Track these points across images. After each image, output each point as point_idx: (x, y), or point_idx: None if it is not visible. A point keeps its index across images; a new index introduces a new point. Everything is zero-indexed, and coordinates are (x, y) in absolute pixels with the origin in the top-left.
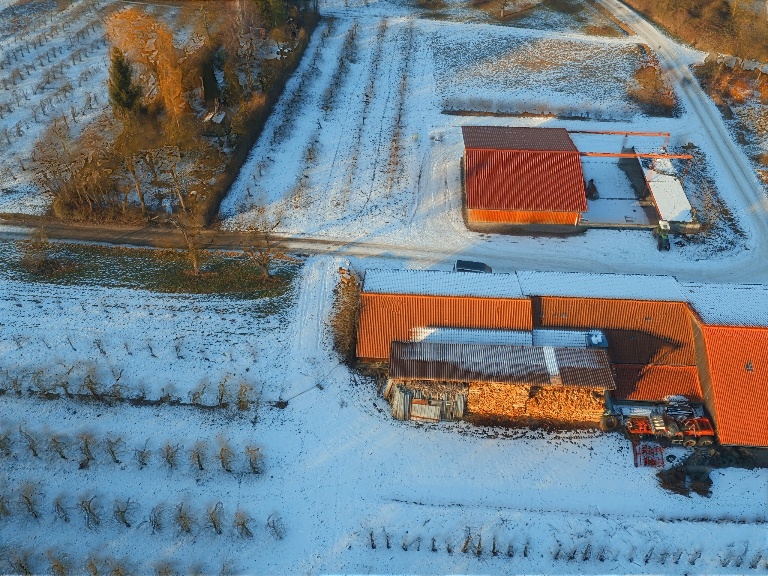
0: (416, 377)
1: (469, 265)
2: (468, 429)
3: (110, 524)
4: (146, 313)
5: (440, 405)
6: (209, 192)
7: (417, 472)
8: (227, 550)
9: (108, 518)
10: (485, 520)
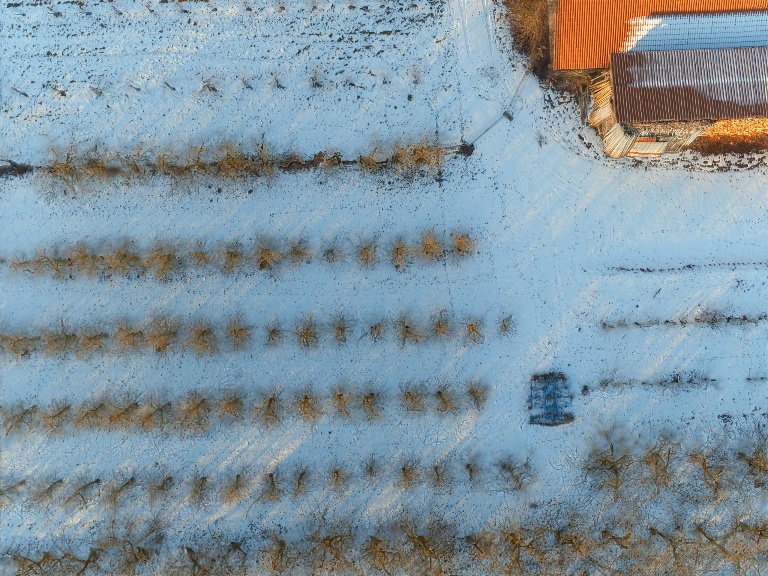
0: (652, 118)
1: None
2: (695, 161)
3: (329, 340)
4: (241, 9)
5: (669, 140)
6: None
7: (640, 229)
8: (454, 346)
9: (327, 338)
10: (719, 283)
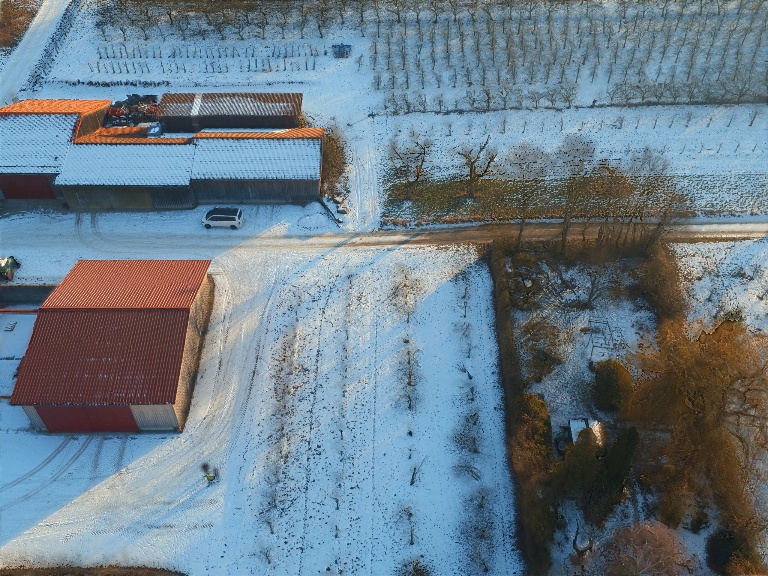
0: None
1: (227, 211)
2: None
3: None
4: None
5: None
6: (510, 283)
7: None
8: None
9: None
10: None
